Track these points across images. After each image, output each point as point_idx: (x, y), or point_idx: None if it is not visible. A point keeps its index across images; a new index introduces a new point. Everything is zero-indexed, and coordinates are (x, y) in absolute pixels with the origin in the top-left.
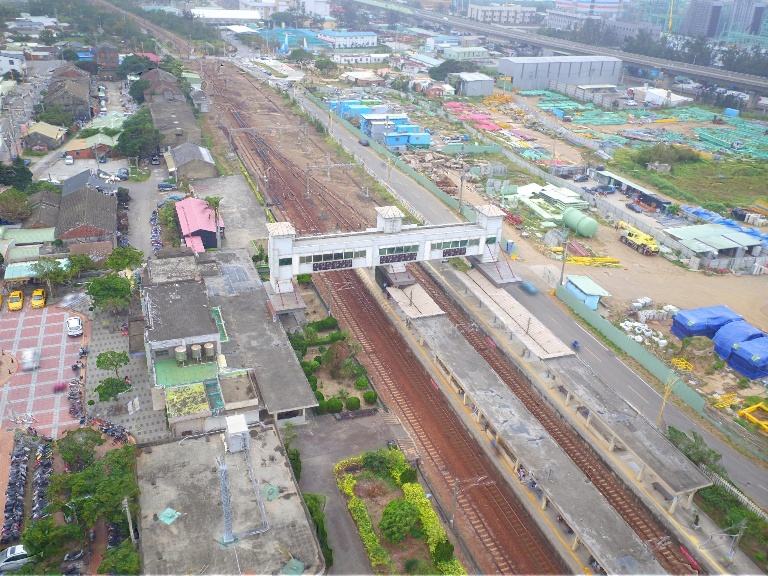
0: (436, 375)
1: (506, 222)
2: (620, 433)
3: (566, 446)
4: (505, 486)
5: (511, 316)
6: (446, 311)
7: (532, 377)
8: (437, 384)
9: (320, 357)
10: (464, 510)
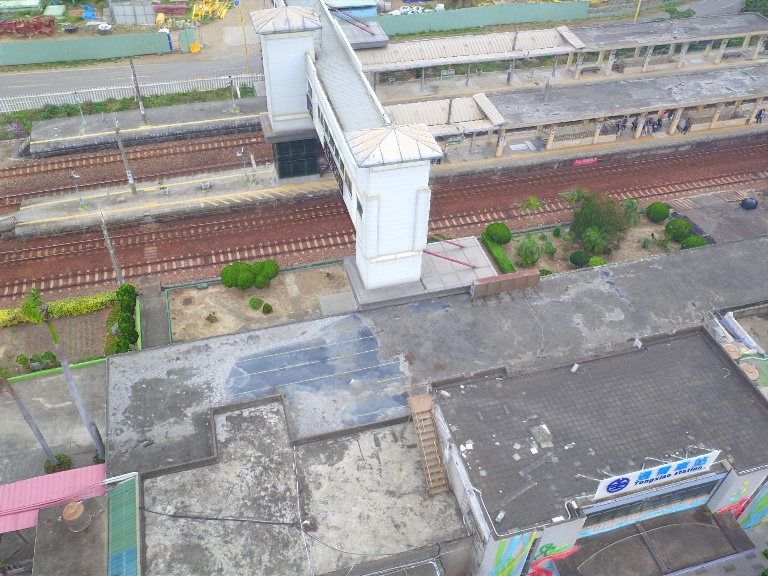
0: (577, 152)
1: (34, 36)
2: None
3: None
4: (759, 140)
5: (462, 55)
6: None
7: (556, 86)
8: (597, 154)
9: (582, 252)
10: None
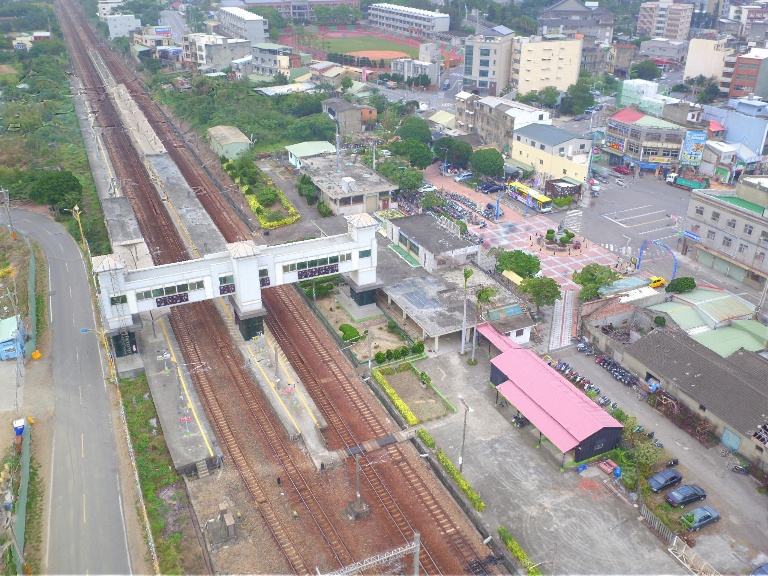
0: None
1: None
2: (130, 212)
3: (154, 243)
4: None
5: None
6: (189, 326)
7: None
8: None
9: None
10: (233, 220)
